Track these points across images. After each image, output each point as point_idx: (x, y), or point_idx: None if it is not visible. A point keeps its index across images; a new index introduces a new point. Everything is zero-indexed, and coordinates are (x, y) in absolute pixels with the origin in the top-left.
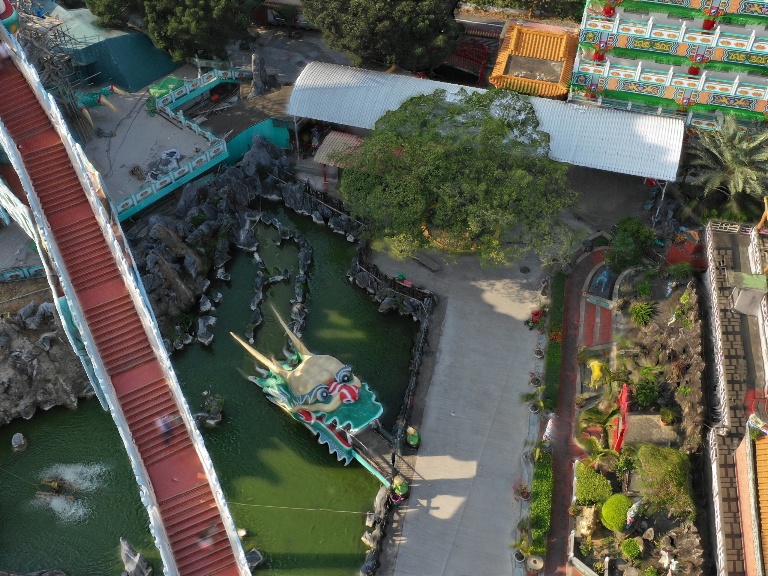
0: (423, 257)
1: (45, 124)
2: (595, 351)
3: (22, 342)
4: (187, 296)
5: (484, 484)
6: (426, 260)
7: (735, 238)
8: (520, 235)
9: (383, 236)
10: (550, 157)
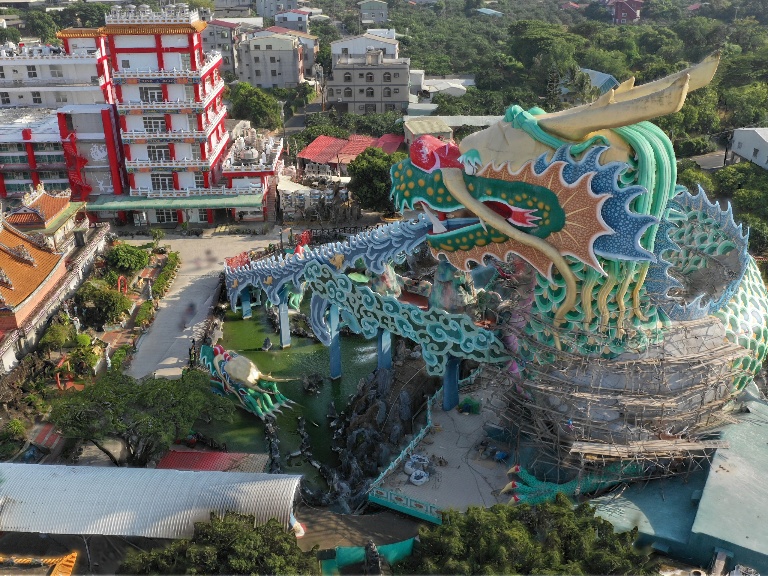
0: None
1: None
2: None
3: None
4: None
5: None
6: None
7: None
8: None
9: None
10: None
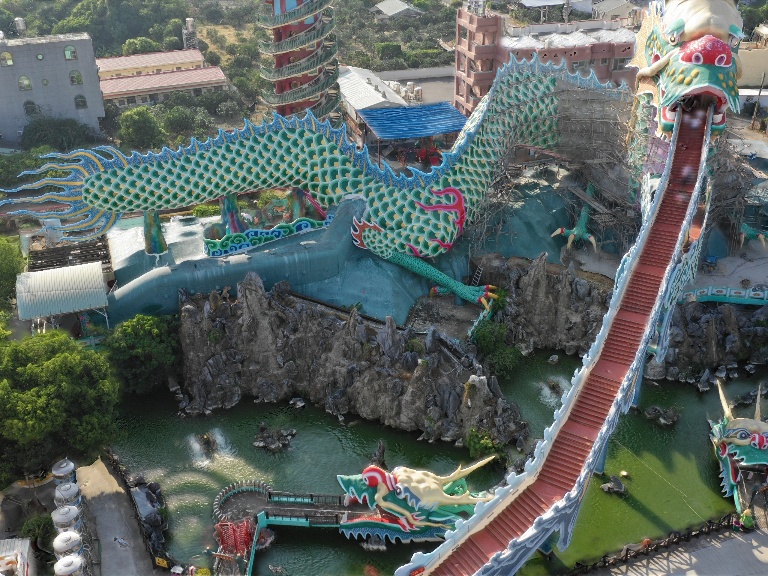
0: None
1: (693, 181)
2: None
3: (597, 309)
4: (713, 358)
5: None
6: None
7: None
8: None
9: None
10: None
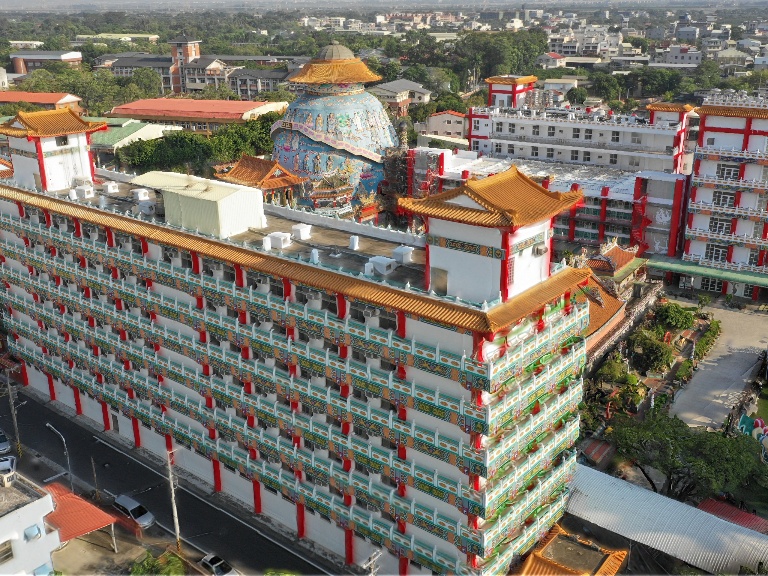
0: None
1: None
2: None
3: None
4: None
5: None
6: None
7: None
8: None
9: None
10: None
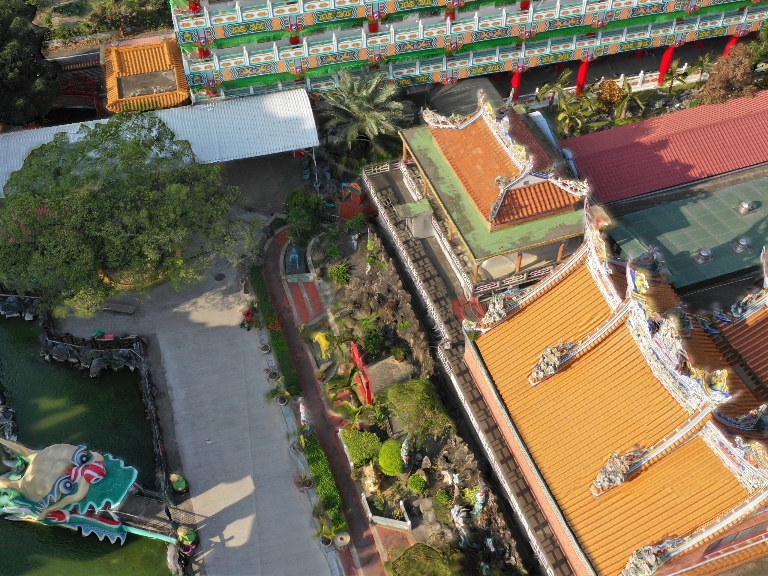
0: (114, 305)
1: None
2: (314, 324)
3: None
4: None
5: (266, 493)
6: (118, 307)
7: (389, 176)
8: (201, 246)
9: (62, 301)
10: (198, 162)
